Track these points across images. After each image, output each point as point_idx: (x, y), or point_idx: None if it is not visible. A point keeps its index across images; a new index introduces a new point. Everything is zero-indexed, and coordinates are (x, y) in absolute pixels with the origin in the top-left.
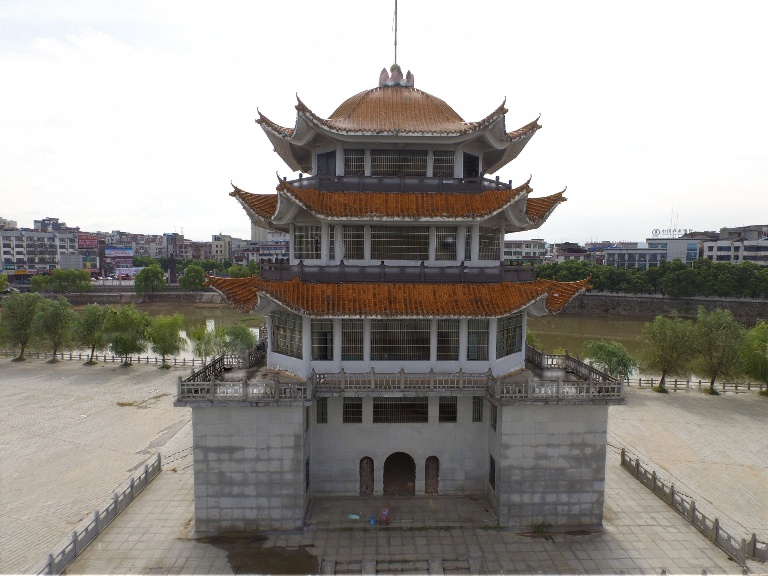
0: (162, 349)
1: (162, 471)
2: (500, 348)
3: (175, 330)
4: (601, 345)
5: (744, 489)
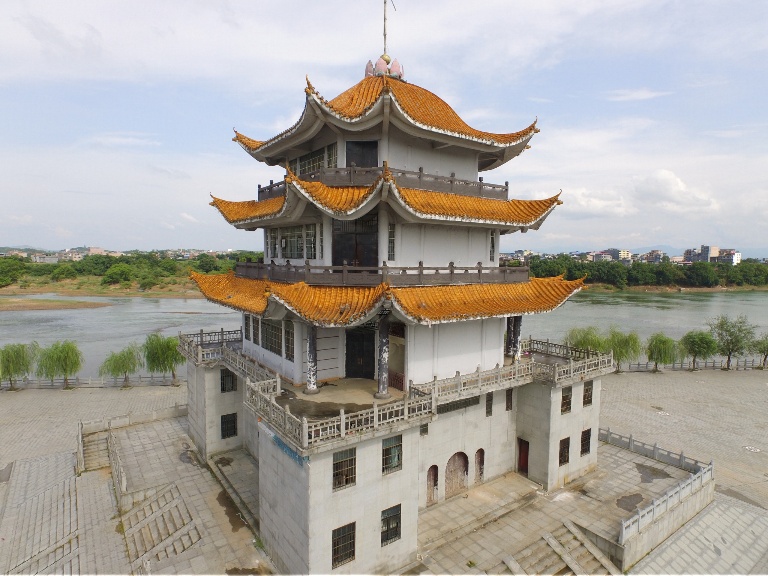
0: None
1: None
2: None
3: None
4: None
5: None
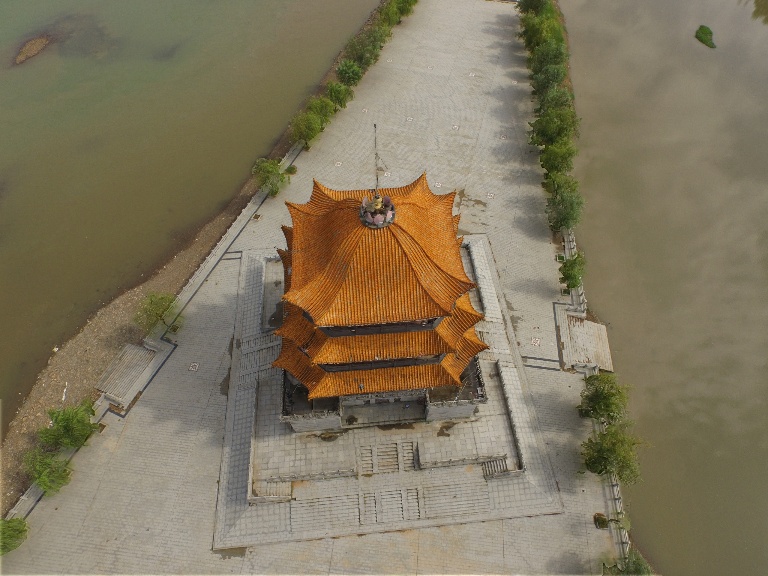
0: None
1: None
2: None
3: (564, 157)
4: (639, 575)
5: (377, 575)
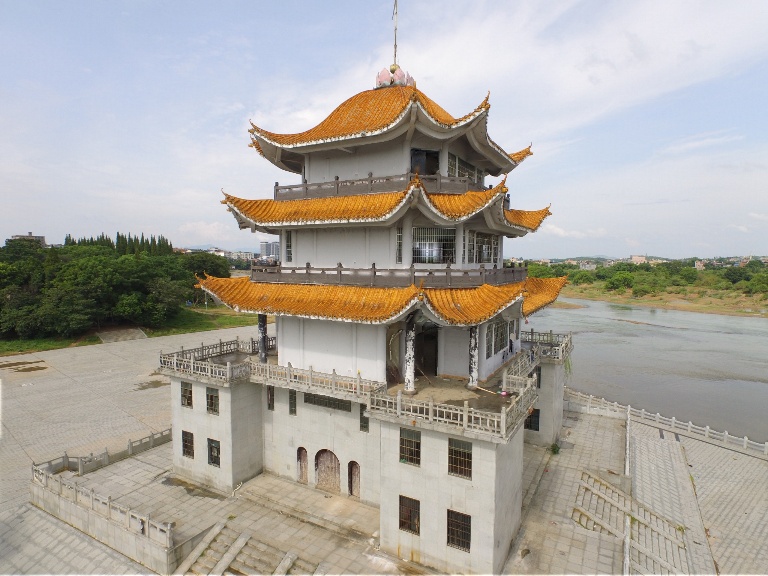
0: None
1: (623, 473)
2: None
3: None
4: None
5: None
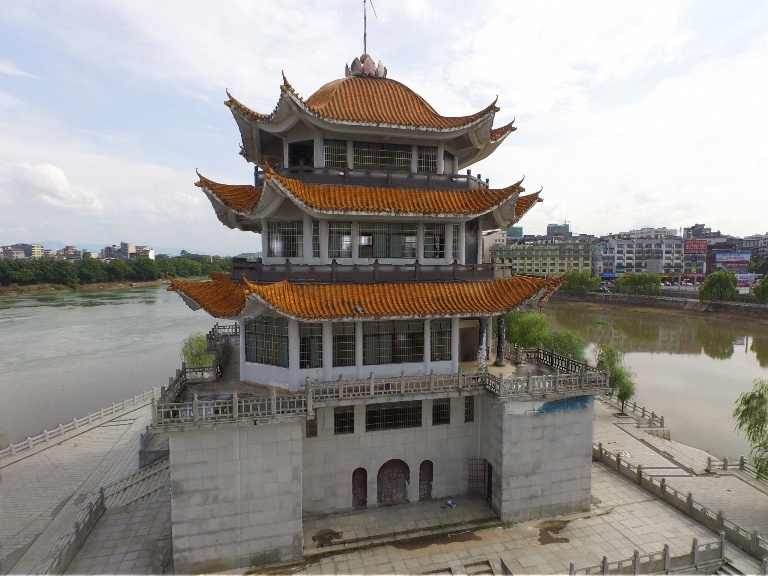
0: (520, 343)
1: None
2: (252, 351)
3: (537, 328)
4: None
5: None
